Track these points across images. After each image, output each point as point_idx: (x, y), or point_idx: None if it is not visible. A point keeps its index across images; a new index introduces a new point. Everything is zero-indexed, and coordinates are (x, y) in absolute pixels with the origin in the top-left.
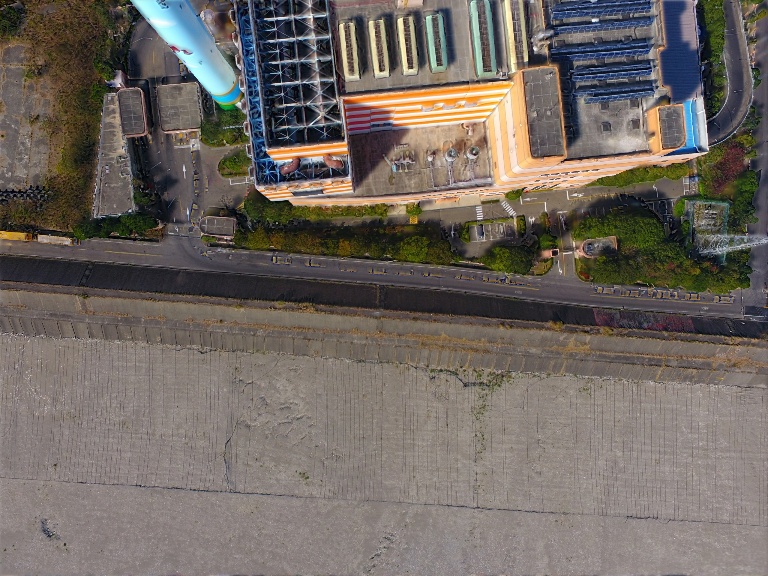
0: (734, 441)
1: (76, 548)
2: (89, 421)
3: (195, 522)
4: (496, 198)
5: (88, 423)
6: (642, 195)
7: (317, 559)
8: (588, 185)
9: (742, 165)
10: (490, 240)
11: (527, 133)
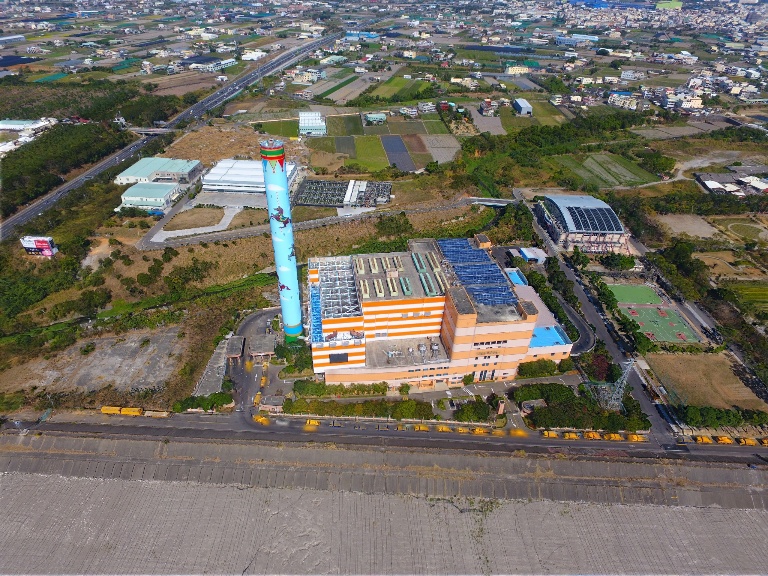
0: (724, 558)
1: None
2: (122, 551)
3: None
4: (458, 386)
5: (121, 553)
6: None
7: None
8: (517, 379)
9: (609, 365)
10: (460, 409)
11: (454, 306)
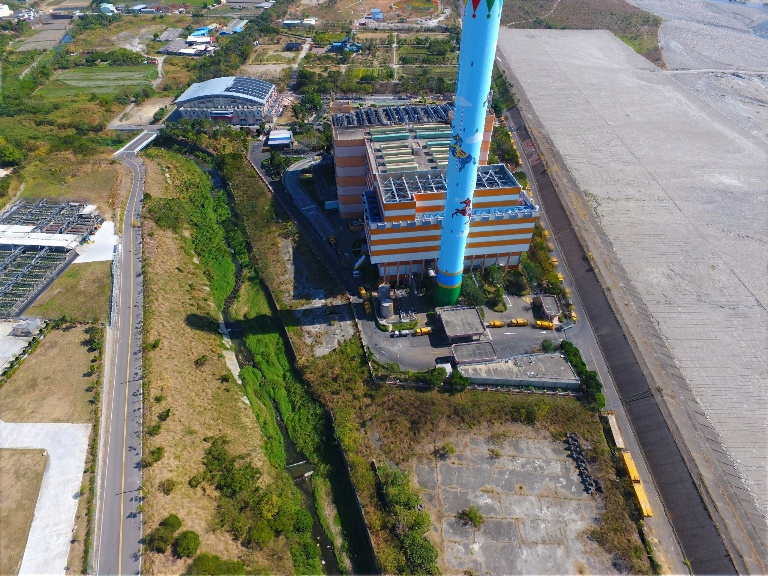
0: None
1: None
2: None
3: None
4: None
5: None
6: None
7: None
8: None
9: None
10: None
11: None
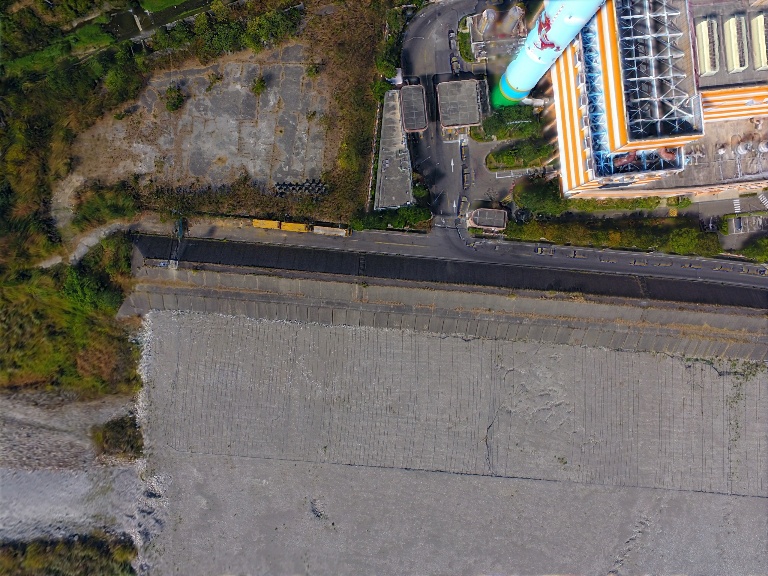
0: None
1: (343, 528)
2: (358, 405)
3: (458, 504)
4: (754, 191)
5: (357, 407)
6: None
7: (574, 542)
8: None
9: None
10: (747, 232)
11: None
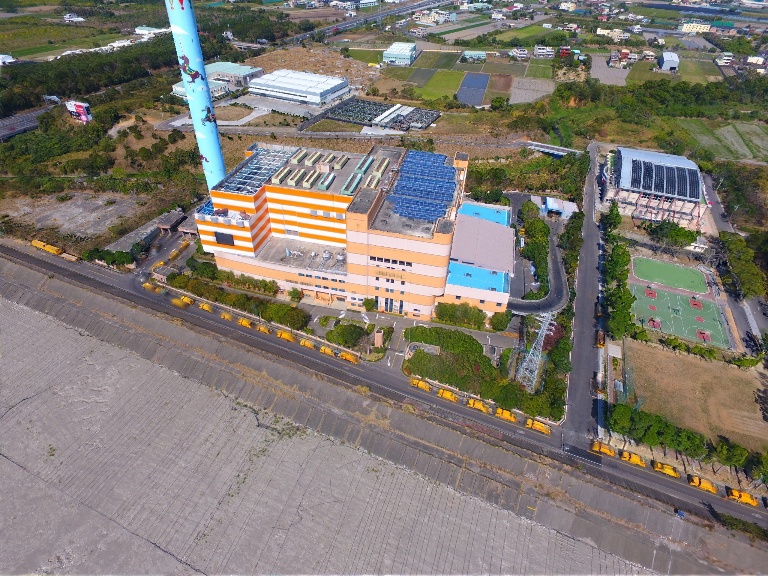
0: None
1: None
2: None
3: None
4: (359, 310)
5: None
6: (476, 339)
7: None
8: (433, 321)
9: None
10: None
11: (350, 203)
